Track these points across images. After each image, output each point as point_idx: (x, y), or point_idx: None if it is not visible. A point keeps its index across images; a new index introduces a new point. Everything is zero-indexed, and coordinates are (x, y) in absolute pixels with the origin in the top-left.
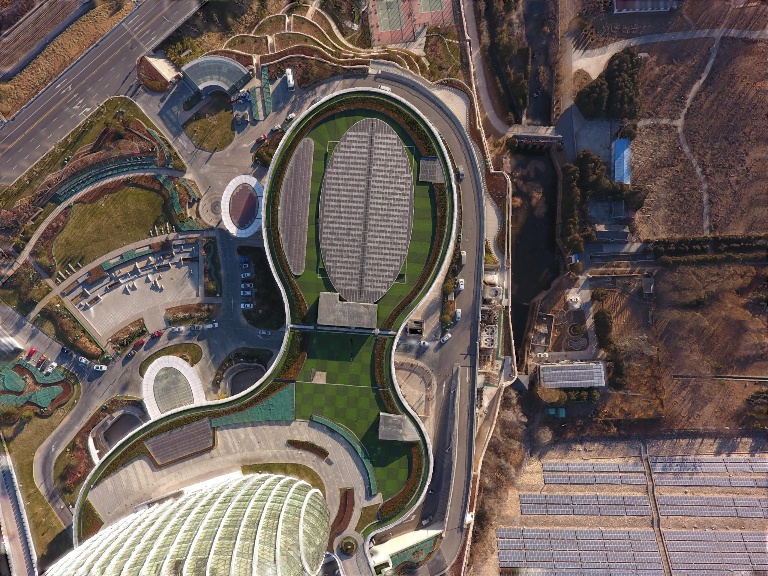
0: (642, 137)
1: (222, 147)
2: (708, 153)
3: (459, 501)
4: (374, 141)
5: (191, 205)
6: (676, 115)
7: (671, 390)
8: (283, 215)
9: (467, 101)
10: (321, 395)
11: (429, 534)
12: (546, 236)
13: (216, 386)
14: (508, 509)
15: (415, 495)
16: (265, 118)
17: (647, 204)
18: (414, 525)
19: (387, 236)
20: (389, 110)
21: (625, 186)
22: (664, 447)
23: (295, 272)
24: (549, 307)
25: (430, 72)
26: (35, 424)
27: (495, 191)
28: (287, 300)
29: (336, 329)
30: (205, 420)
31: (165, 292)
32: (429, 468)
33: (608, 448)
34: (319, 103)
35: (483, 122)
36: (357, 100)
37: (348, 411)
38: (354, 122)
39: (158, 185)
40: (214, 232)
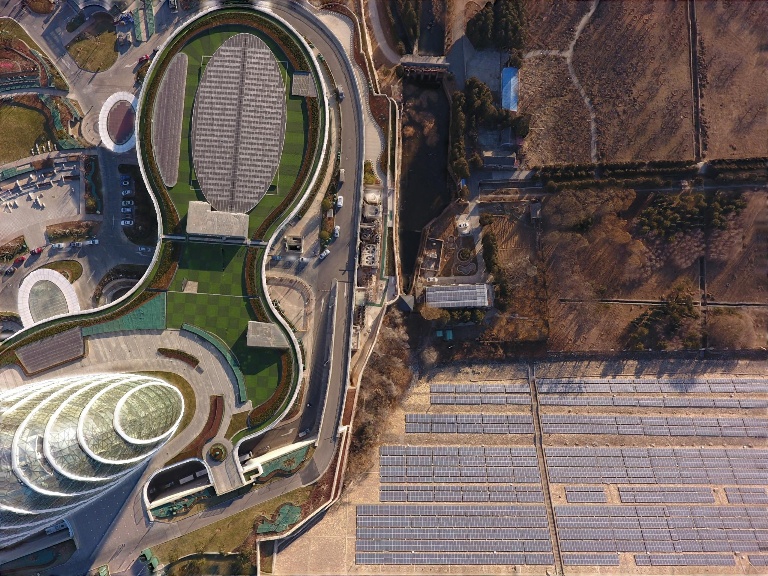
0: (532, 68)
1: (105, 67)
2: (596, 83)
3: (333, 412)
4: (247, 55)
5: (73, 124)
6: (565, 46)
7: (558, 314)
8: (156, 128)
9: (351, 26)
10: (192, 304)
11: (302, 444)
12: (438, 165)
13: (95, 302)
14: (393, 428)
15: (284, 402)
16: (148, 39)
17: (536, 133)
18: (292, 438)
19: (259, 148)
20: (262, 26)
21: (510, 112)
22: (551, 369)
23: (168, 184)
24: (439, 233)
25: (319, 0)
26: None
27: (378, 113)
28: (159, 211)
29: (208, 240)
30: (76, 329)
31: (46, 210)
32: (298, 375)
33: (496, 370)
34: (193, 19)
35: (375, 52)
36: (231, 16)
37: (219, 320)
38: (228, 37)
39: (40, 104)
40: (96, 151)
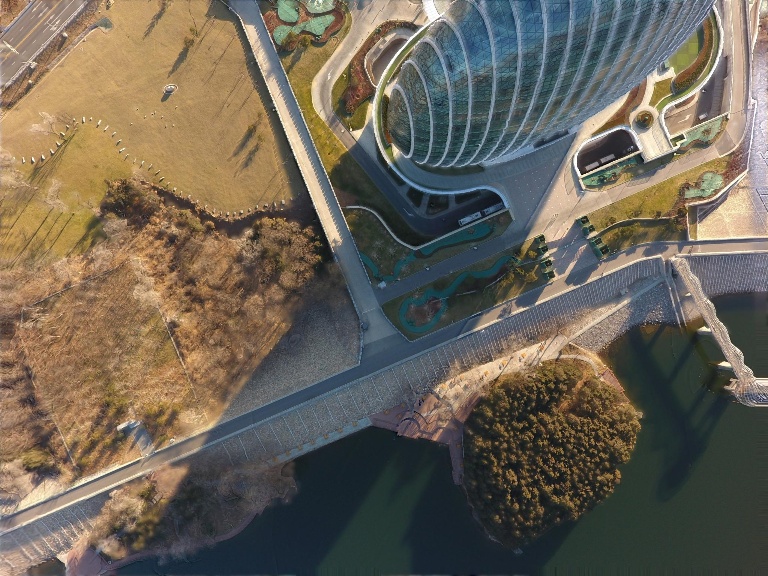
0: None
1: None
2: None
3: (740, 87)
4: None
5: None
6: None
7: None
8: None
9: None
10: None
11: None
12: None
13: None
14: (765, 128)
15: (707, 67)
16: None
17: None
18: (689, 124)
19: None
20: None
21: None
22: None
23: None
24: None
25: None
26: (311, 53)
27: None
28: None
29: None
30: None
31: None
32: (719, 39)
33: None
34: None
35: None
36: None
37: None
38: None
39: None
40: None
